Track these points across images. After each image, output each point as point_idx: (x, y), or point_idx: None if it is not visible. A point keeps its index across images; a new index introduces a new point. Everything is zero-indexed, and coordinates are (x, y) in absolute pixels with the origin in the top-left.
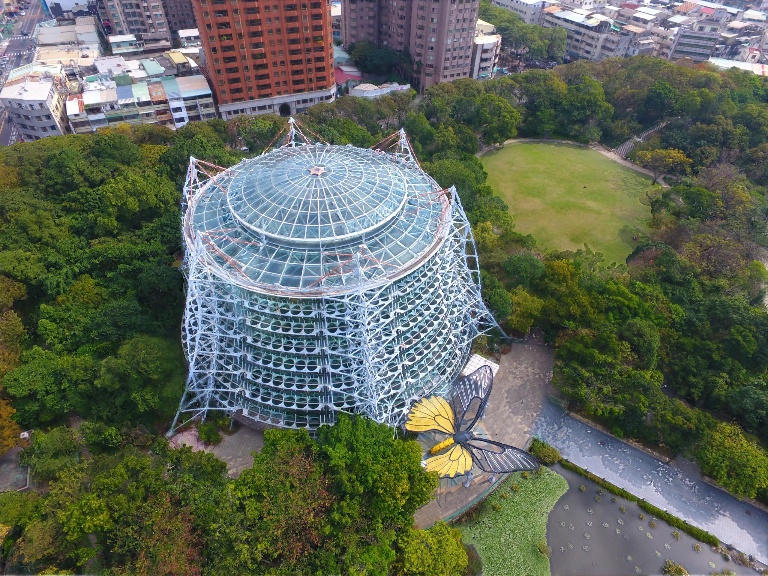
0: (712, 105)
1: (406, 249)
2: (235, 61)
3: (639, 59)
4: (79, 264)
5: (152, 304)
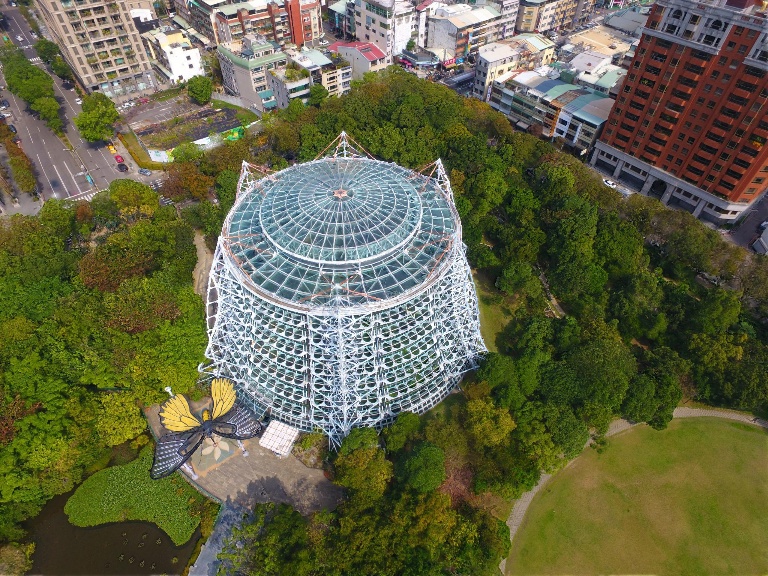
0: None
1: (280, 284)
2: (642, 110)
3: None
4: None
5: None
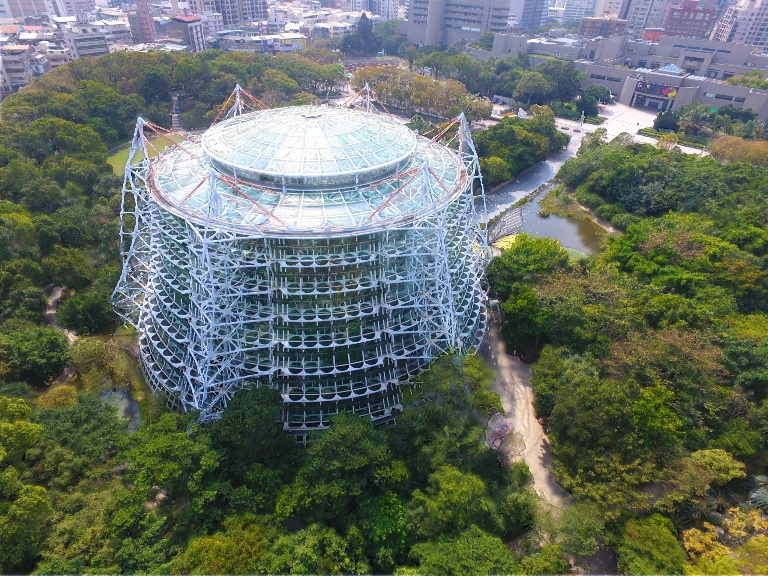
0: (200, 67)
1: None
2: None
3: (82, 62)
4: (139, 571)
5: (270, 463)
